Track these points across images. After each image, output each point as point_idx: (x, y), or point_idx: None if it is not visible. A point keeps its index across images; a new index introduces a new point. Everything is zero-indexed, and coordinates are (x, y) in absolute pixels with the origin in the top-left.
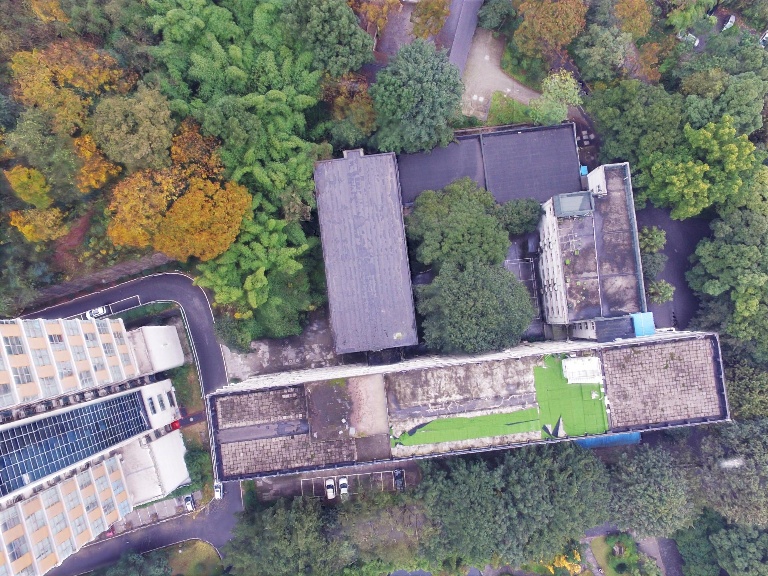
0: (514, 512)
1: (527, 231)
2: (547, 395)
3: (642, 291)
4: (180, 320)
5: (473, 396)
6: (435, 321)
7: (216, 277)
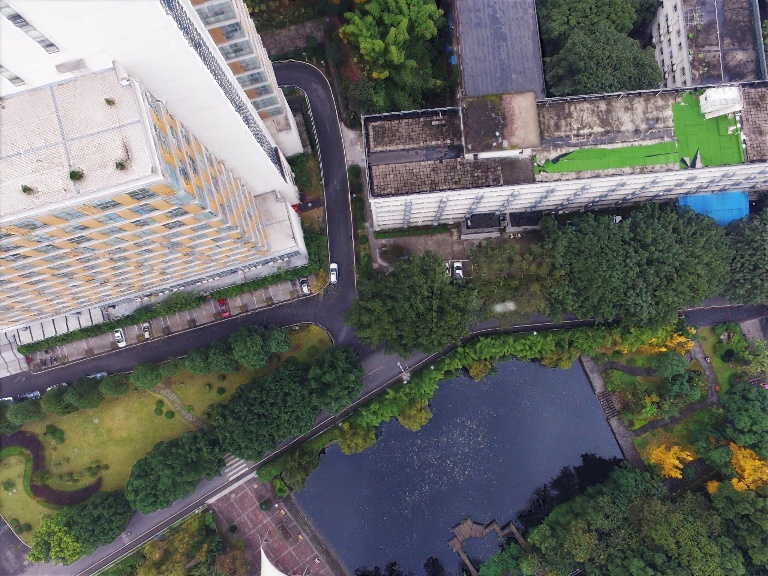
0: (646, 253)
1: (644, 20)
2: (685, 130)
3: (763, 62)
4: (299, 114)
5: (614, 129)
6: (564, 85)
7: (363, 25)
